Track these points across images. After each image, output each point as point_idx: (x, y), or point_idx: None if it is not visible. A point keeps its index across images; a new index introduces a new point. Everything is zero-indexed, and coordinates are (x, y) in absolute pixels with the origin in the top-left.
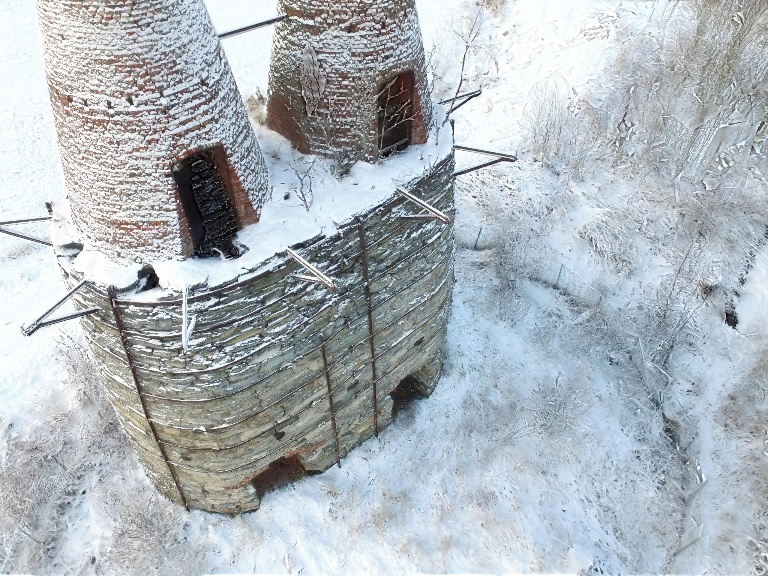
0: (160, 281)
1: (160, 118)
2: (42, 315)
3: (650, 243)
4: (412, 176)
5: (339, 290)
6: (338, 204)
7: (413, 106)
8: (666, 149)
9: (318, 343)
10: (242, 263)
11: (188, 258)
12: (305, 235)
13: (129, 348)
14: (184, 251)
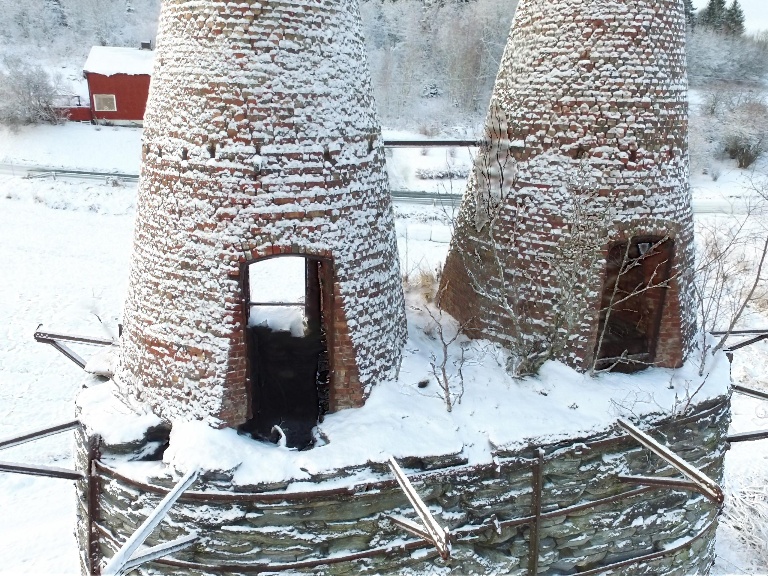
0: (166, 449)
1: (245, 184)
2: None
3: None
4: (649, 407)
5: None
6: (504, 415)
7: (665, 300)
8: None
9: None
10: (304, 459)
11: (228, 427)
12: (430, 446)
13: (98, 559)
14: (225, 412)
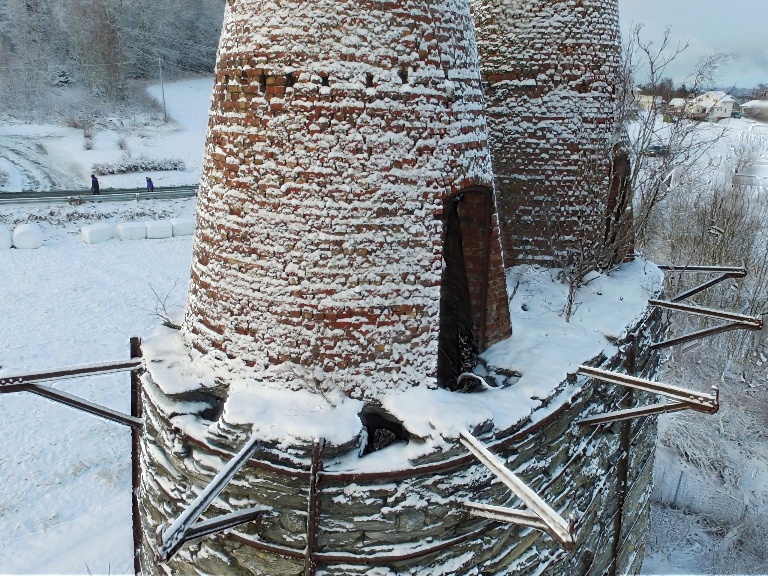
0: (410, 425)
1: (440, 112)
2: (192, 508)
3: (737, 446)
4: (653, 288)
5: (605, 462)
6: (598, 314)
7: (623, 208)
8: (702, 349)
9: (580, 569)
10: (530, 388)
11: None
12: (588, 350)
13: None
14: None
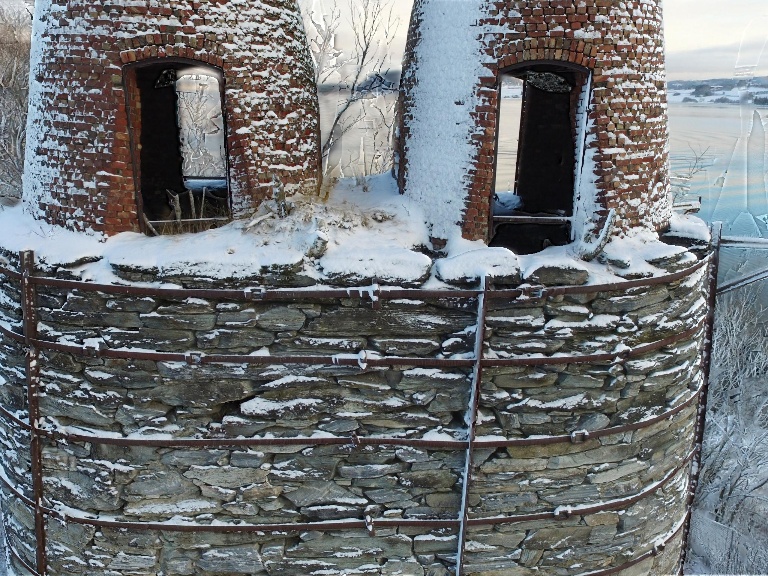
0: None
1: None
2: (684, 204)
3: None
4: None
5: None
6: None
7: None
8: None
9: None
10: None
11: None
12: None
13: None
14: None
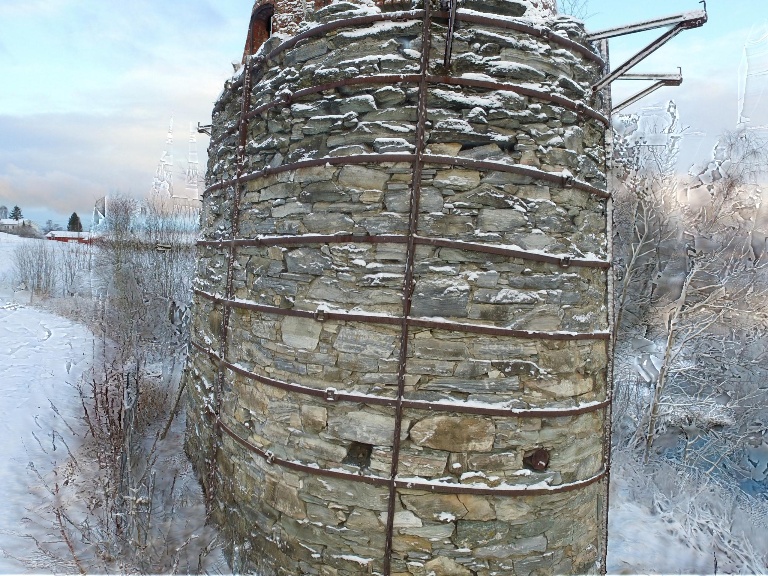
0: None
1: None
2: (670, 18)
3: None
4: None
5: None
6: None
7: None
8: None
9: None
10: None
11: None
12: None
13: None
14: None
